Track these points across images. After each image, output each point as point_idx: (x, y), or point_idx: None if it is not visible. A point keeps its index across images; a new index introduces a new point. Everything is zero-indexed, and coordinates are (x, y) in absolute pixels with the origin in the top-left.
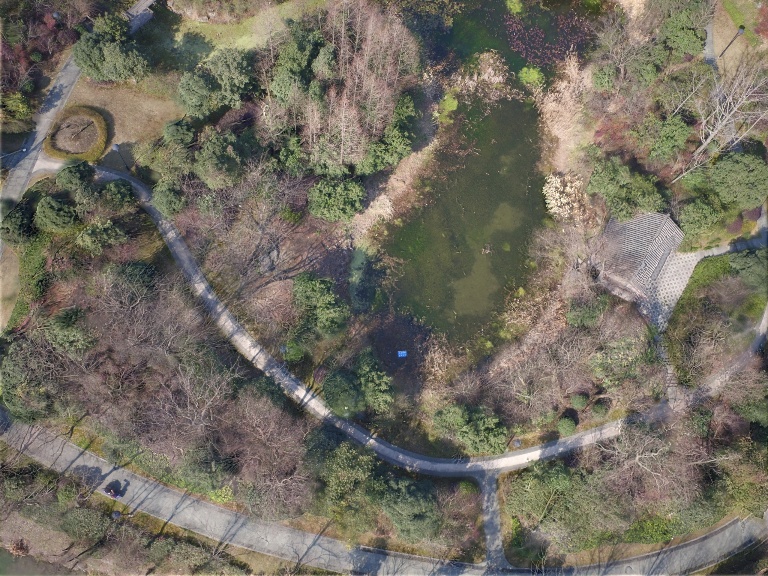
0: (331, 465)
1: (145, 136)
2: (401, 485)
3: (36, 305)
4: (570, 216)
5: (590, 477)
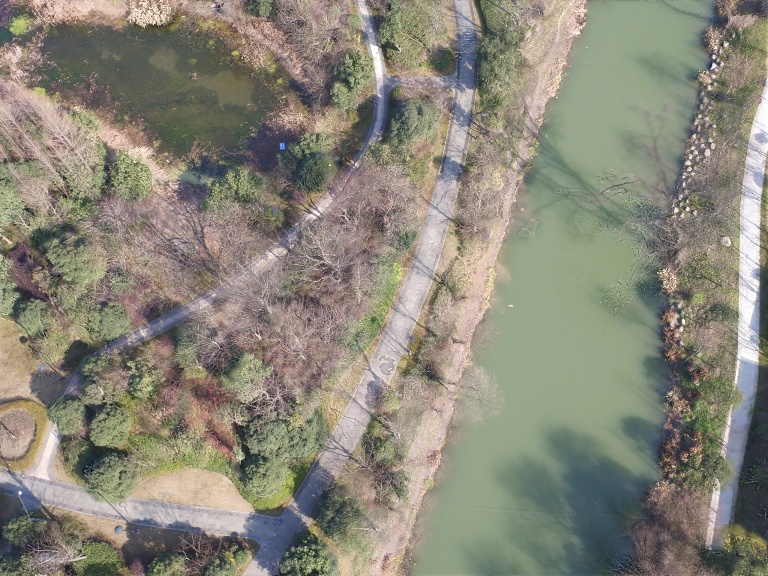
0: (377, 172)
1: (25, 365)
2: (394, 128)
3: (209, 436)
4: (171, 7)
5: (393, 7)
